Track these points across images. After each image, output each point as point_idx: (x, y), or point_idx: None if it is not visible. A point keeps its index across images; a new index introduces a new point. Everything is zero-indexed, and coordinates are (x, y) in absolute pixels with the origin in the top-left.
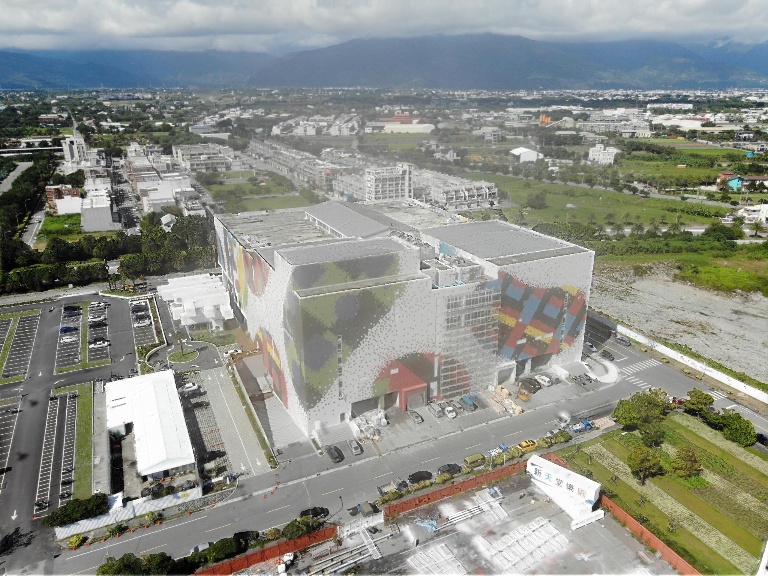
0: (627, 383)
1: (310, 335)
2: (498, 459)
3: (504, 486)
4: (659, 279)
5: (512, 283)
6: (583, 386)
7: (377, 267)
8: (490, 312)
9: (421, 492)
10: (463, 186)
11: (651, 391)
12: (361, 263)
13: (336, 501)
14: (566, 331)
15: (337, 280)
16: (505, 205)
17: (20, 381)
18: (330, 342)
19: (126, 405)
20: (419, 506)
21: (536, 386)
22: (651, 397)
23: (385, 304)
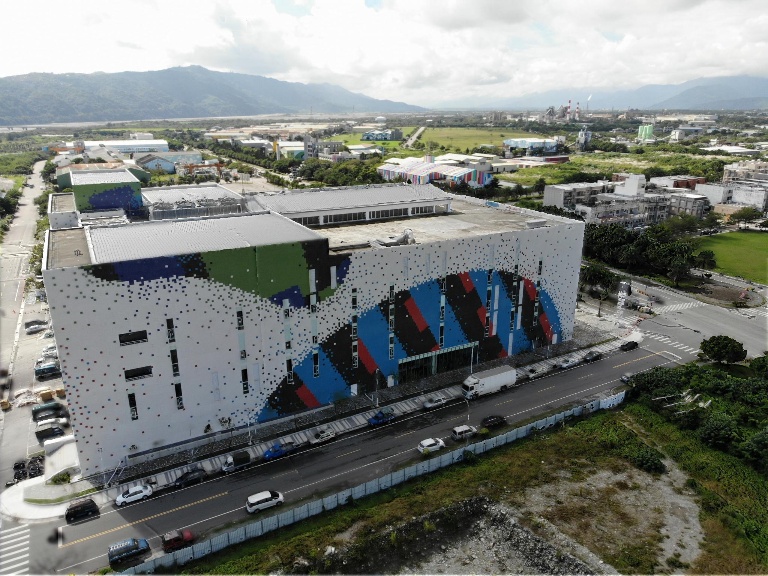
0: None
1: None
2: None
3: None
4: None
5: None
6: None
7: None
8: None
9: None
10: None
11: None
12: None
13: None
14: None
15: None
16: None
17: None
18: None
19: None
20: None
21: None
22: None
23: None
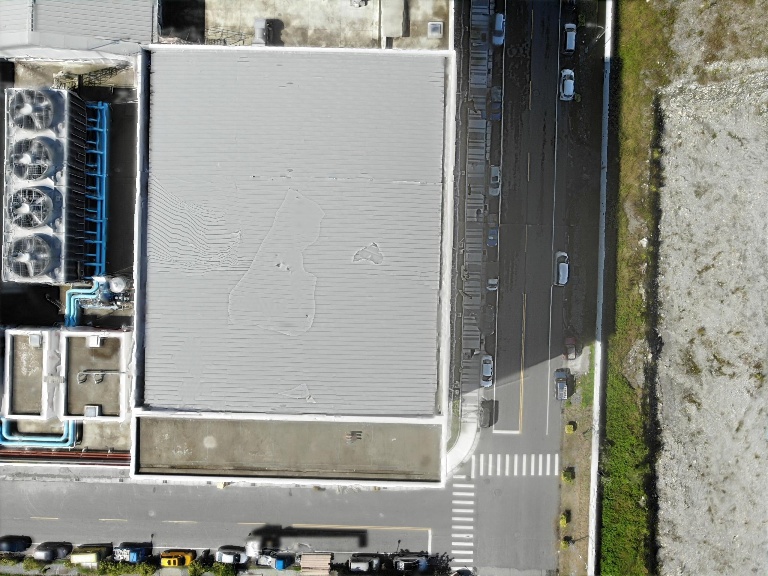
0: (444, 496)
1: None
2: (110, 575)
3: None
4: None
5: None
6: None
7: None
8: None
9: (1, 566)
10: None
11: None
12: None
13: None
14: None
15: None
16: None
17: None
18: None
19: None
20: None
21: None
22: None
23: None
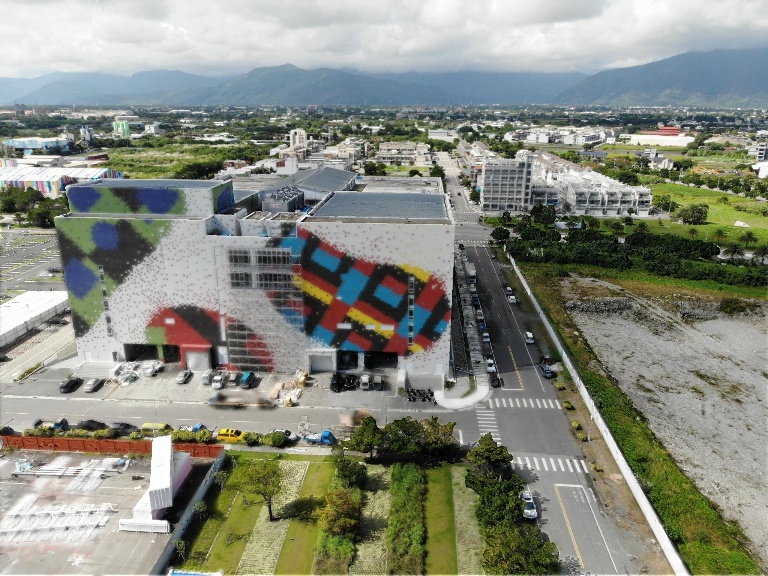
0: (469, 415)
1: (69, 258)
2: None
3: (142, 463)
4: (762, 323)
5: (320, 247)
6: (407, 402)
7: (161, 202)
8: (290, 278)
9: None
10: (604, 189)
11: (432, 421)
12: (141, 195)
13: (4, 421)
14: (417, 328)
15: (116, 209)
16: (657, 217)
17: (1, 281)
18: (91, 270)
19: (8, 307)
20: (45, 449)
21: (344, 384)
22: (417, 426)
23: (150, 241)
